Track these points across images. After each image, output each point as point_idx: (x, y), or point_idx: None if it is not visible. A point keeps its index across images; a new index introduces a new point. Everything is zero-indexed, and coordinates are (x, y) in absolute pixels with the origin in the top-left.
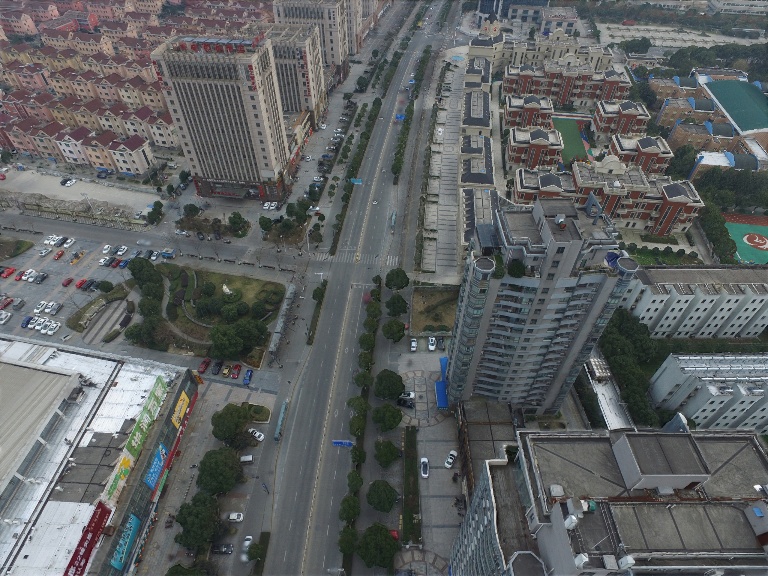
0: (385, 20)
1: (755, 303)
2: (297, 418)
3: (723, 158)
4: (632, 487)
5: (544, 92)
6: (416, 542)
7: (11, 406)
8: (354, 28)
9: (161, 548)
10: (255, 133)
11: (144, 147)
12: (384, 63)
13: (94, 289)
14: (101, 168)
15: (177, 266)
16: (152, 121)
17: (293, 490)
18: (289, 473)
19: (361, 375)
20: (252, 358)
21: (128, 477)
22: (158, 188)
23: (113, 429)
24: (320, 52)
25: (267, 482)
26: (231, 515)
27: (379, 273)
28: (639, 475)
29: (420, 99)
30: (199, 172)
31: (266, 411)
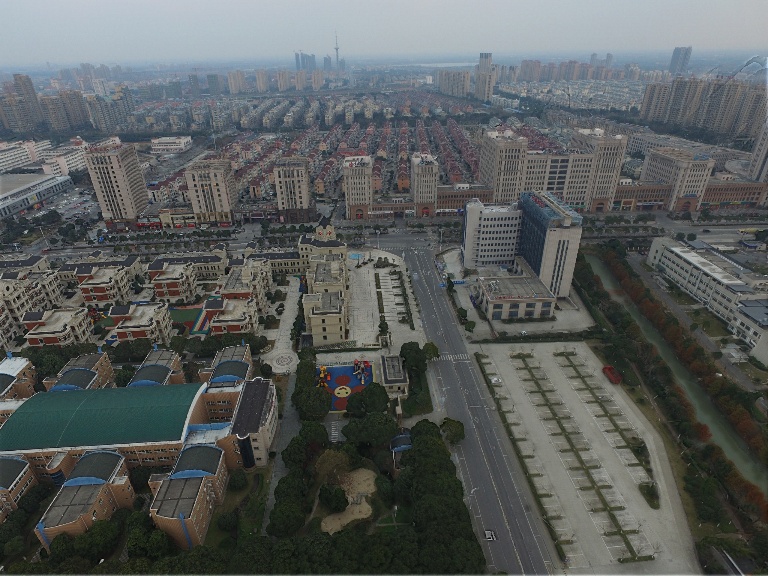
0: (453, 218)
1: None
2: None
3: None
4: None
5: None
6: None
7: None
8: (346, 199)
9: None
10: None
11: (155, 191)
12: None
13: None
14: None
15: (62, 224)
16: None
17: None
18: None
19: None
20: None
21: None
22: None
23: None
24: (223, 186)
25: None
26: None
27: None
28: None
29: None
30: None
31: None
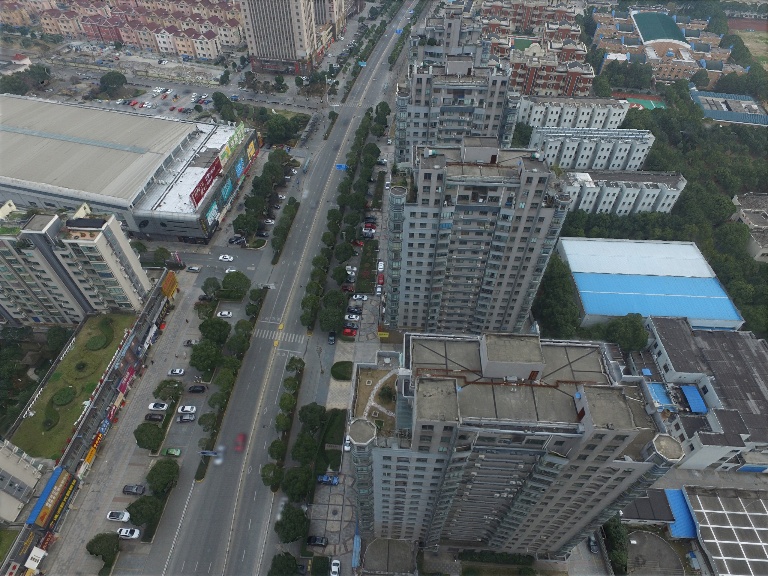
0: None
1: (600, 116)
2: (316, 167)
3: (624, 57)
4: (447, 72)
5: (511, 20)
6: (378, 208)
7: (163, 131)
8: None
9: (242, 205)
10: (295, 20)
11: (216, 39)
12: (392, 1)
13: (190, 111)
14: (184, 55)
15: (241, 104)
16: (220, 24)
17: (313, 191)
18: (311, 185)
19: (355, 144)
20: (290, 142)
21: (228, 161)
22: (226, 65)
23: (217, 147)
24: None
25: (299, 187)
26: (279, 195)
27: (373, 112)
28: (447, 61)
29: (417, 25)
30: (255, 52)
31: (298, 162)
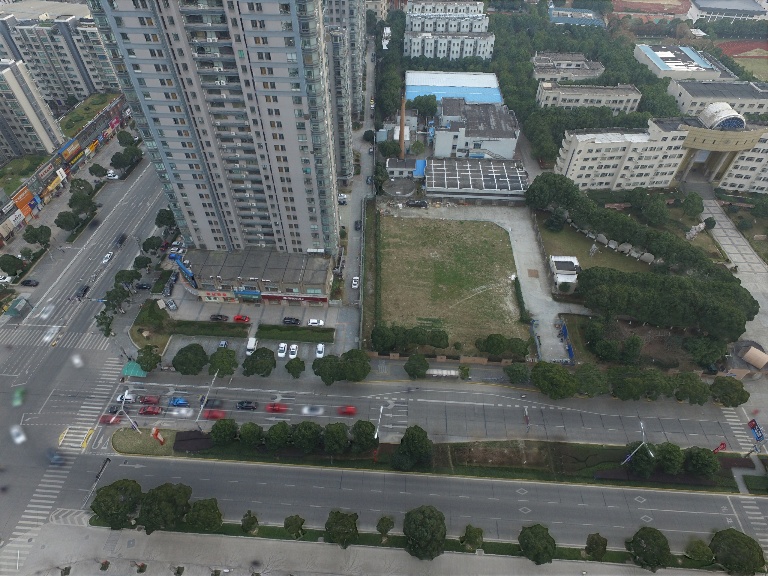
0: None
1: (461, 12)
2: None
3: None
4: None
5: None
6: None
7: None
8: None
9: None
10: None
11: None
12: None
13: None
14: None
15: None
16: None
17: None
18: None
19: None
20: None
21: None
22: None
23: None
24: None
25: None
26: None
27: None
28: None
29: None
30: None
31: None
